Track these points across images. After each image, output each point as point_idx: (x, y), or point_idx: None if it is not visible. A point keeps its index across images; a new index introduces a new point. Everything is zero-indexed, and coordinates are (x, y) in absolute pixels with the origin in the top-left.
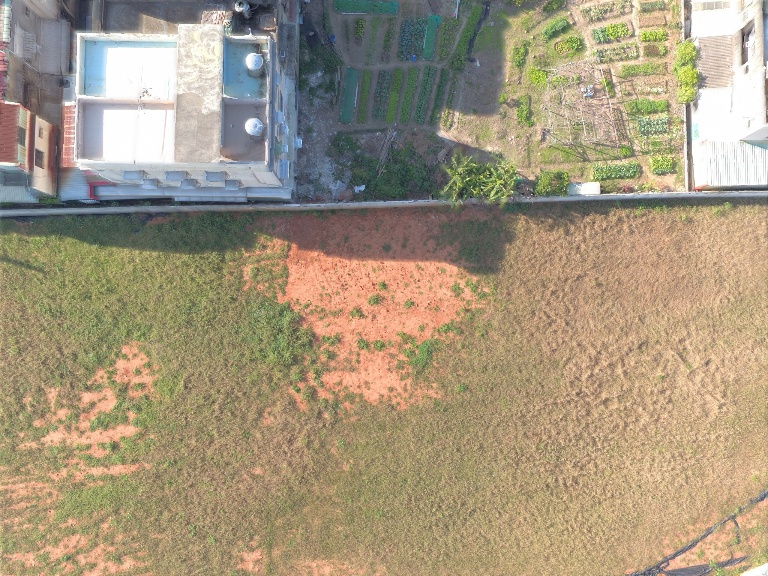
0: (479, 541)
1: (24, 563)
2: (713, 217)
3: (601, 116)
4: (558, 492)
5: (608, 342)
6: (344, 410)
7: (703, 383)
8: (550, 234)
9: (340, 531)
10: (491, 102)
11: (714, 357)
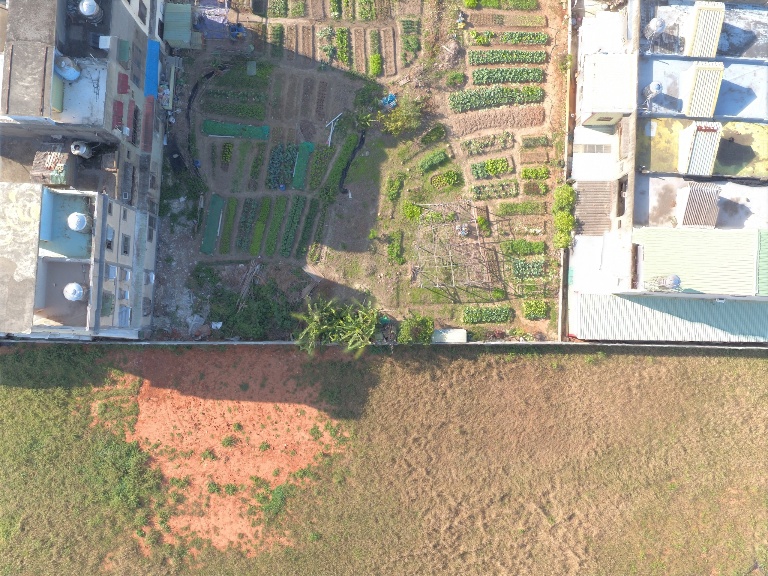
0: None
1: None
2: (585, 366)
3: None
4: None
5: (469, 494)
6: (191, 556)
7: (565, 538)
8: (416, 378)
9: None
10: (361, 236)
11: (578, 512)
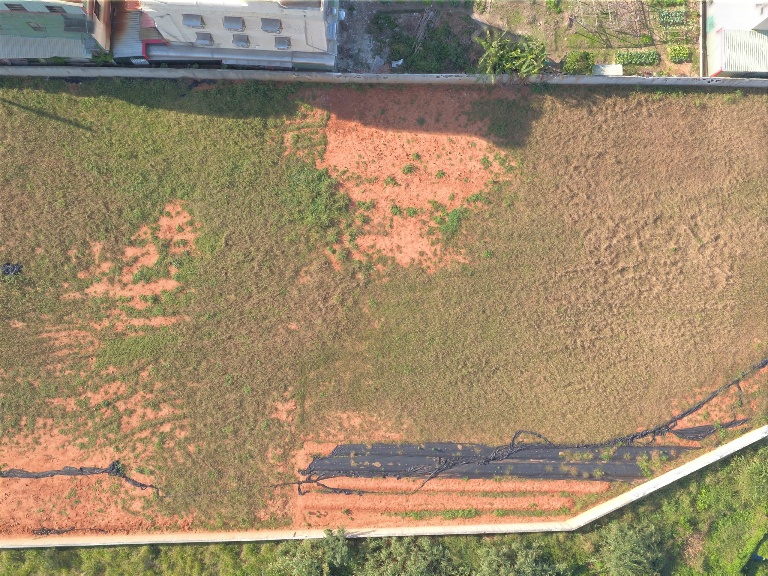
0: (502, 397)
1: (66, 407)
2: (724, 104)
3: (624, 6)
4: (576, 354)
5: (626, 215)
6: (377, 271)
7: (712, 257)
8: (574, 114)
9: (371, 385)
10: None
11: (723, 233)
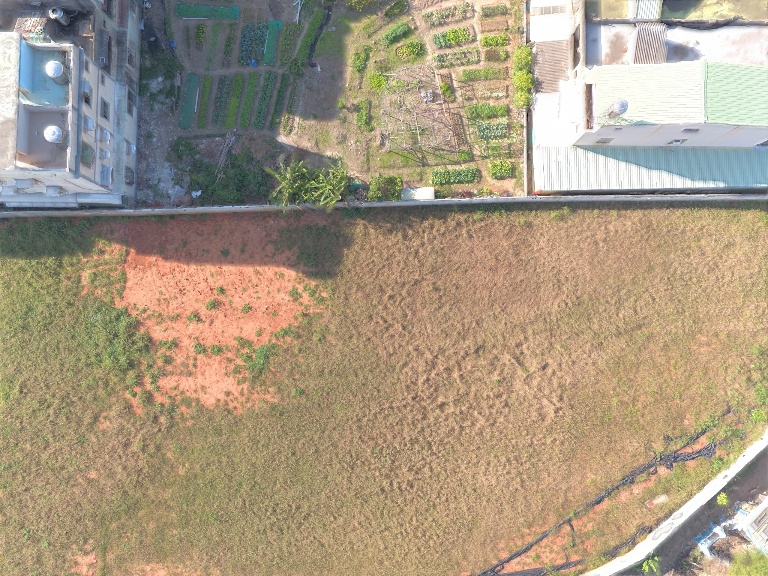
0: (313, 545)
1: None
2: (552, 222)
3: (441, 121)
4: (393, 496)
5: (444, 346)
6: (180, 414)
7: (540, 387)
8: (389, 239)
9: (174, 535)
10: (331, 107)
11: (551, 361)
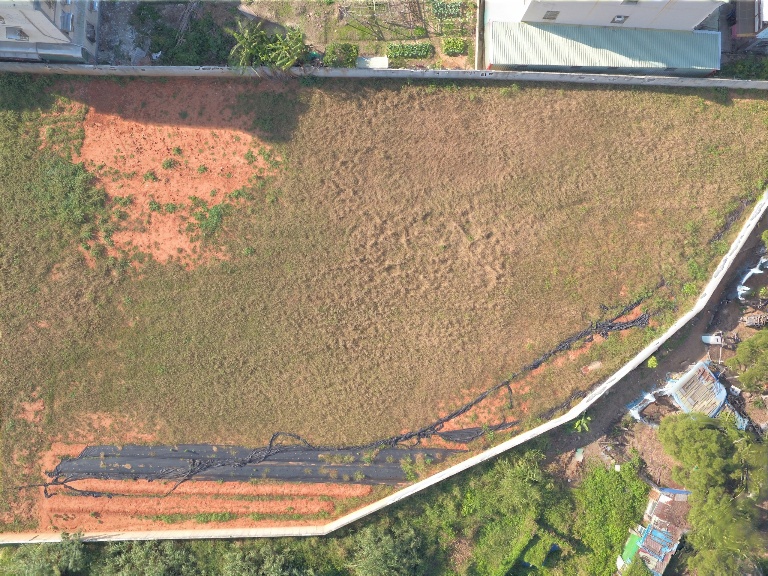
0: (259, 398)
1: None
2: (501, 98)
3: None
4: (338, 354)
5: (393, 212)
6: (133, 268)
7: (484, 255)
8: (343, 108)
9: (123, 384)
10: None
11: (495, 230)
